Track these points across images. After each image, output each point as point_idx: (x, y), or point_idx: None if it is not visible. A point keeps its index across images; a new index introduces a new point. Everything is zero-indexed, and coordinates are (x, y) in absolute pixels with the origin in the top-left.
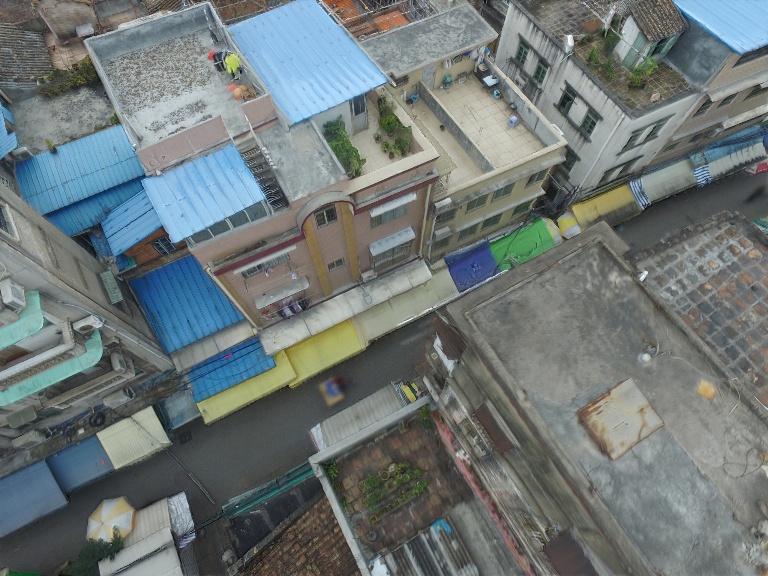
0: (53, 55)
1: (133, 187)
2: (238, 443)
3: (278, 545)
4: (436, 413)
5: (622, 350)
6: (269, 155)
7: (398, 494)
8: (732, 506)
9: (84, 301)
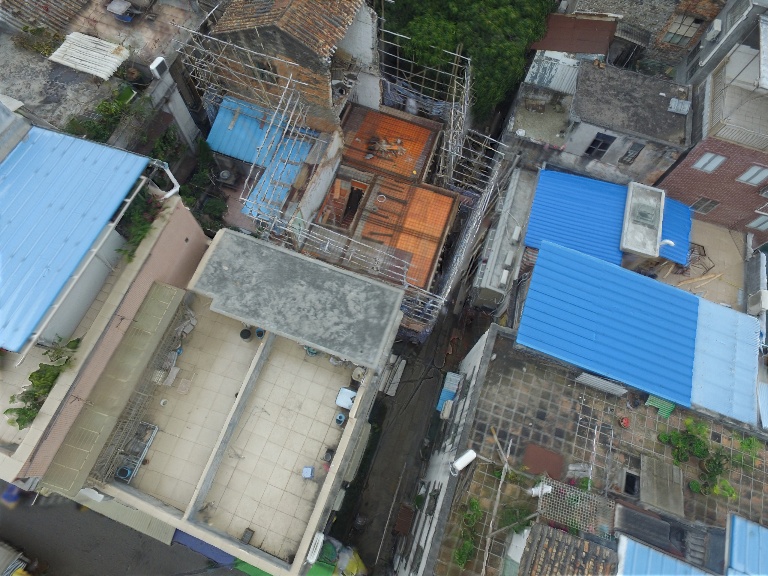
0: (88, 9)
1: None
2: None
3: None
4: None
5: None
6: None
7: None
8: None
9: None
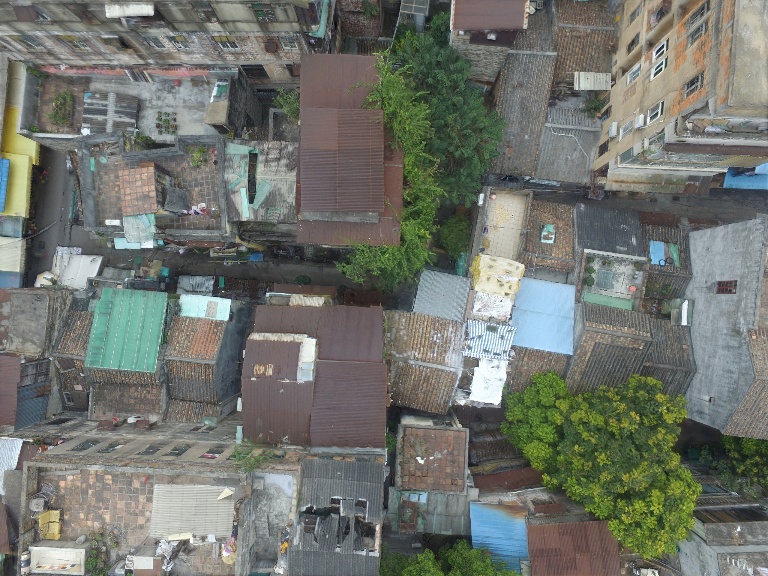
0: None
1: None
2: None
3: None
4: (38, 66)
5: None
6: None
7: None
8: None
9: None
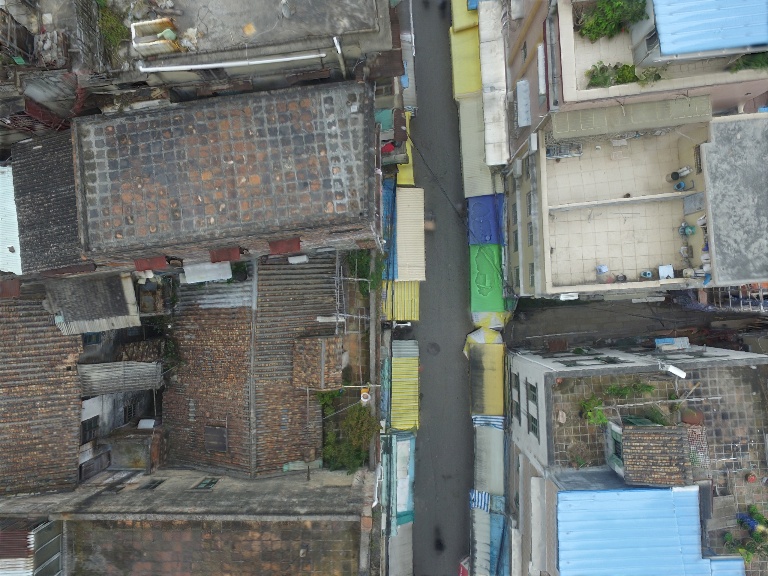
0: None
1: None
2: None
3: None
4: None
5: None
6: None
7: None
8: None
9: None
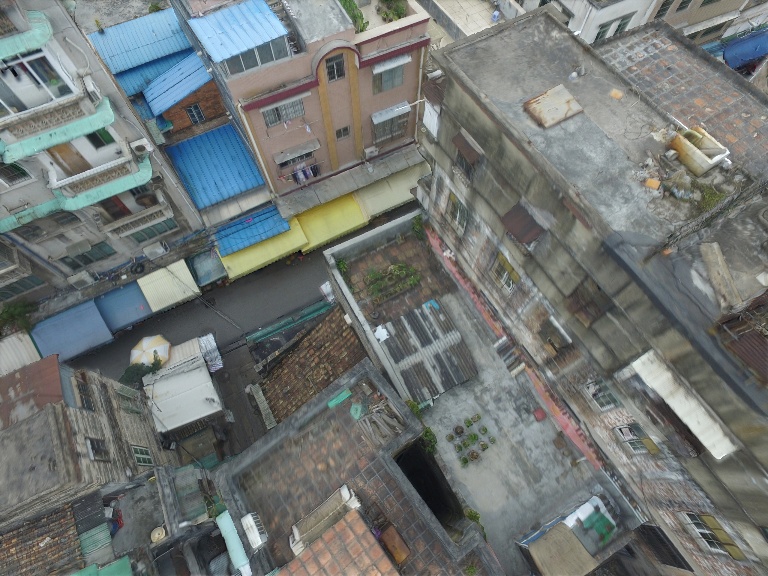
0: None
1: (169, 62)
2: (256, 307)
3: (295, 353)
4: (427, 224)
5: (558, 73)
6: (290, 8)
7: (396, 287)
8: (628, 154)
9: (139, 124)
